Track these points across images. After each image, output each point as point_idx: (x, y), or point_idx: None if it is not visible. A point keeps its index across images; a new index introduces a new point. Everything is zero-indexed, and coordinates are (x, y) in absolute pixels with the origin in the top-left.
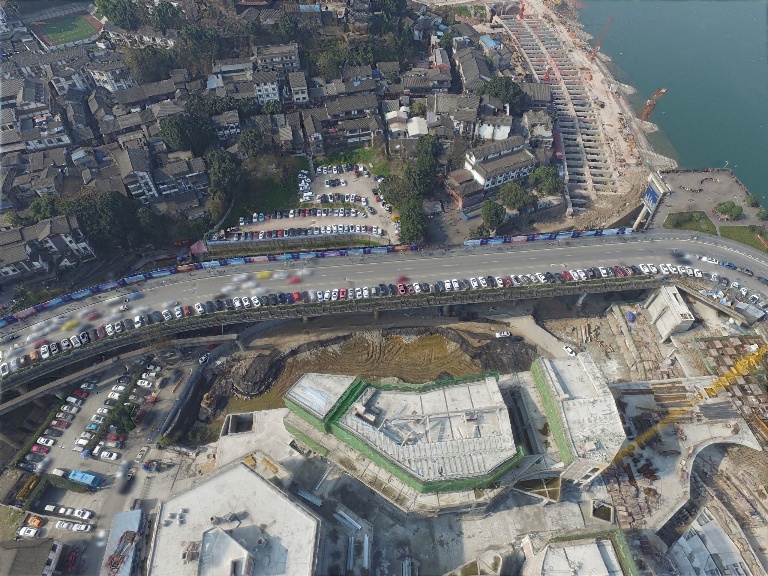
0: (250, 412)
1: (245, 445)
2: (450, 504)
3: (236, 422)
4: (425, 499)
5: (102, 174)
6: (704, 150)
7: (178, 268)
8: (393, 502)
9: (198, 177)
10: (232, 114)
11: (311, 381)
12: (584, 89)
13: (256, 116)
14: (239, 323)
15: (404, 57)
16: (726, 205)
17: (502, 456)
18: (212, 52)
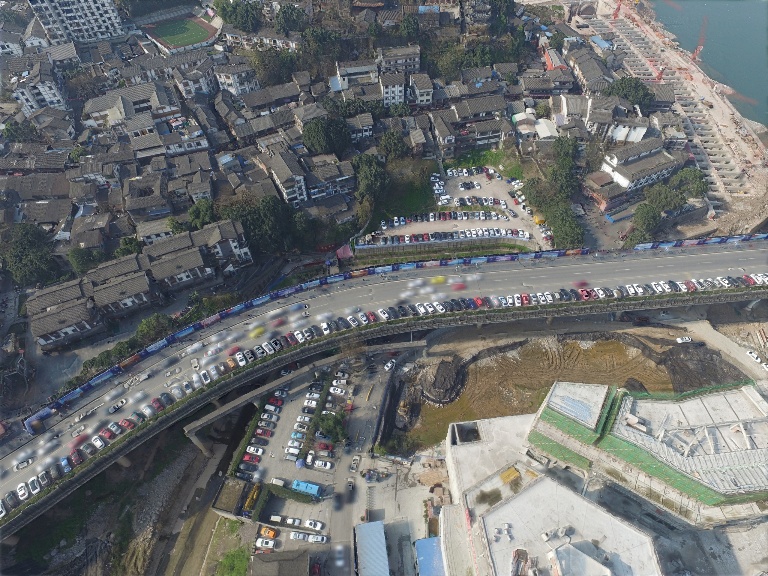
0: (473, 421)
1: (480, 455)
2: (737, 517)
3: (461, 431)
4: (709, 511)
5: (247, 178)
6: None
7: (352, 273)
8: (678, 515)
9: (347, 181)
10: (366, 117)
11: (565, 390)
12: (686, 89)
13: (386, 119)
14: (427, 329)
15: (519, 58)
16: None
17: None
18: (333, 54)
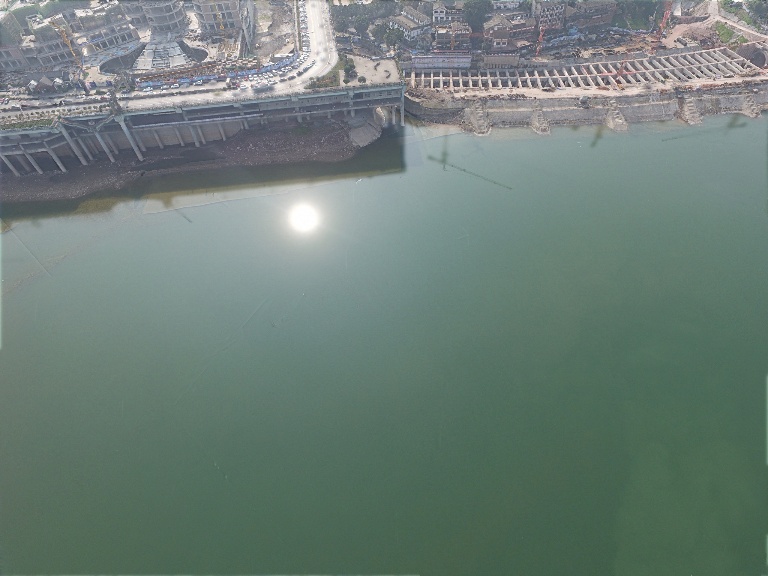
0: None
1: None
2: None
3: None
4: None
5: None
6: (512, 154)
7: None
8: None
9: None
10: None
11: None
12: None
13: None
14: None
15: None
16: None
17: None
18: None
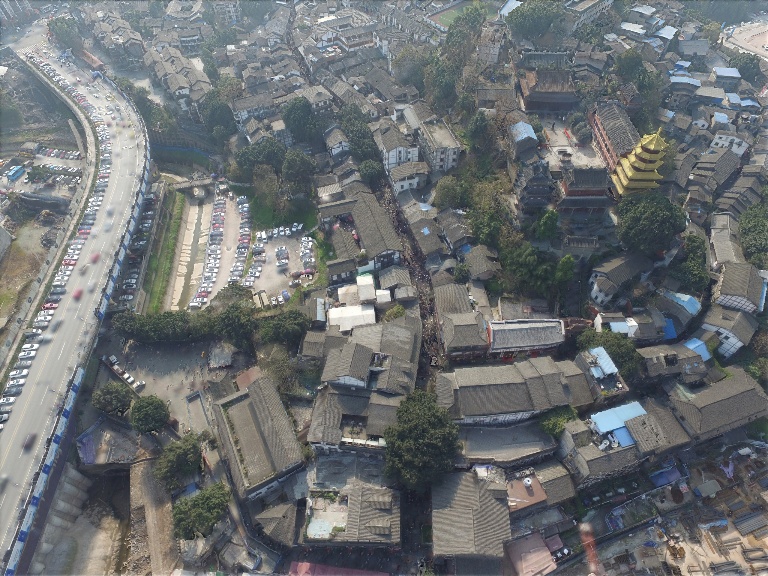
0: None
1: None
2: None
3: None
4: None
5: None
6: None
7: None
8: None
9: None
10: (337, 139)
11: None
12: None
13: (352, 160)
14: None
15: None
16: None
17: None
18: None
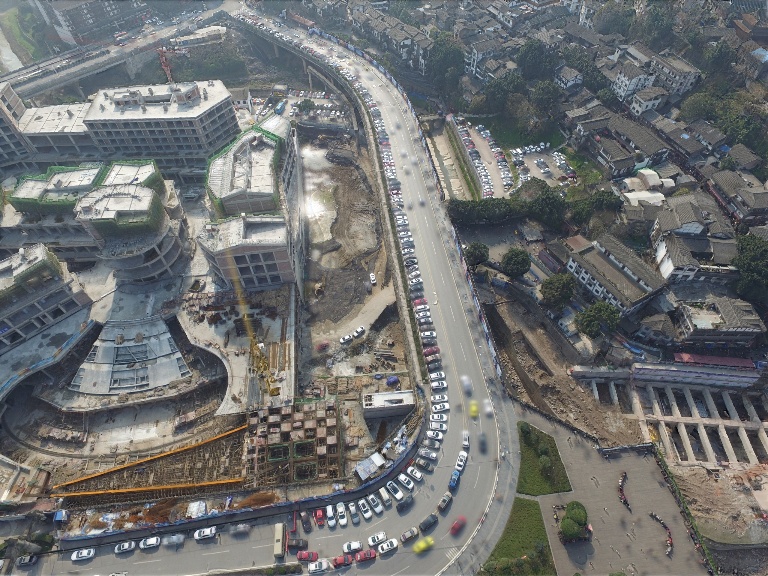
0: None
1: None
2: None
3: None
4: None
5: None
6: None
7: None
8: None
9: None
10: (573, 73)
11: (284, 122)
12: None
13: (587, 90)
14: None
15: None
16: (575, 508)
17: (217, 193)
18: None
